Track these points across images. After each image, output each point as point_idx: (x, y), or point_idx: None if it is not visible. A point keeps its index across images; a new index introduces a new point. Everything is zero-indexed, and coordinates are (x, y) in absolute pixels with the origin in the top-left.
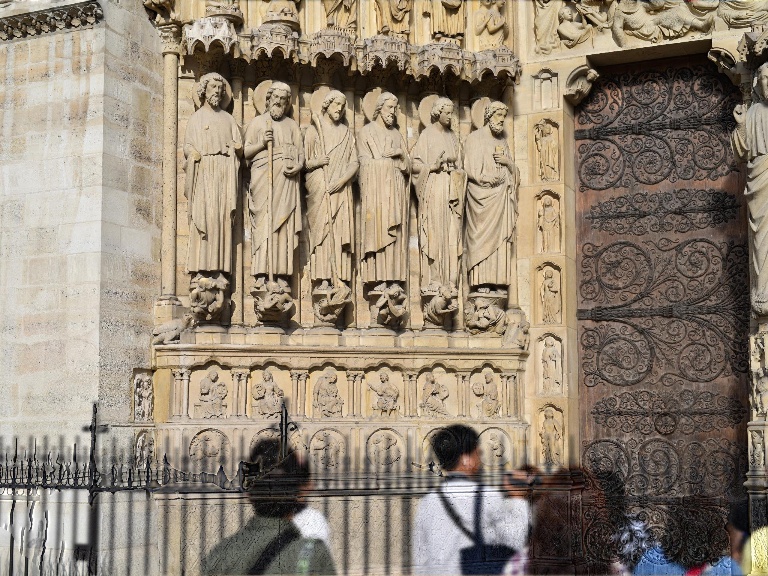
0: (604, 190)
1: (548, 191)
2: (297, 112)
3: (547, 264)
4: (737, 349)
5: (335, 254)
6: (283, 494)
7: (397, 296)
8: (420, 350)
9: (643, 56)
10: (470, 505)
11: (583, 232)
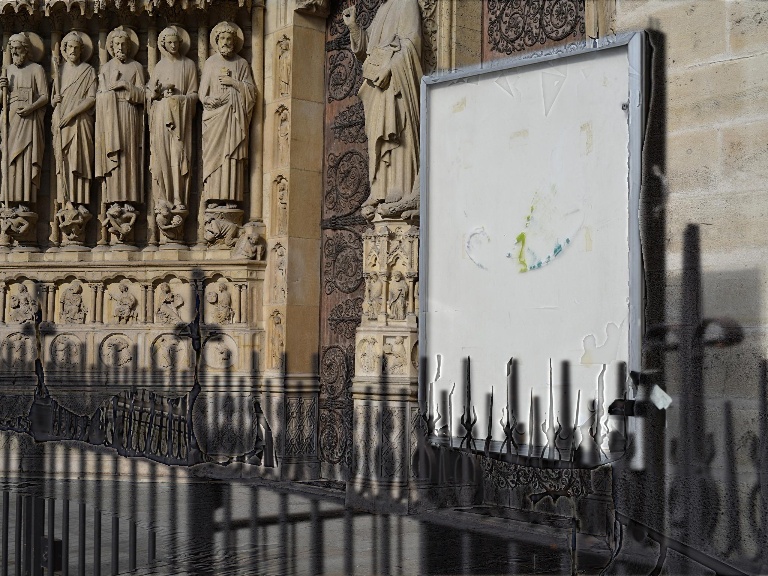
0: (343, 100)
1: (283, 106)
2: (56, 57)
3: (282, 177)
4: None
5: (69, 181)
6: (25, 388)
7: (119, 215)
8: (149, 263)
9: None
10: None
11: (329, 143)
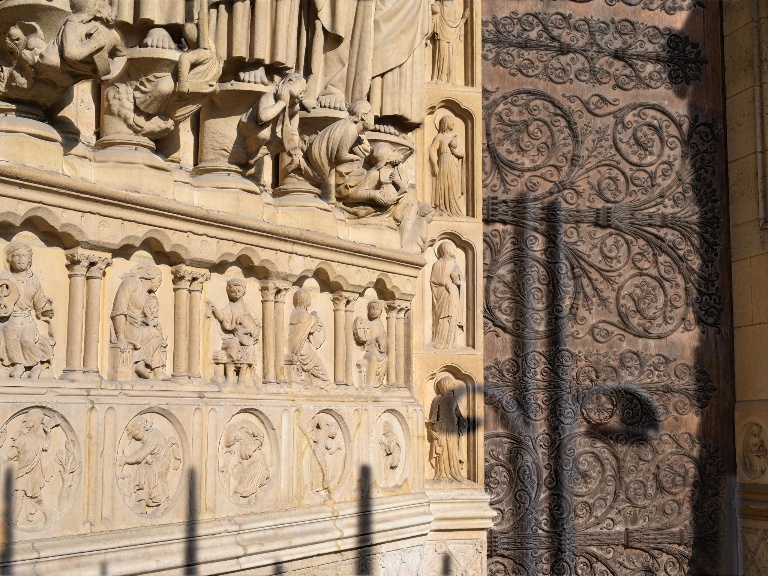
0: None
1: None
2: None
3: (444, 104)
4: (703, 288)
5: None
6: None
7: None
8: (306, 235)
9: None
10: (362, 574)
11: None
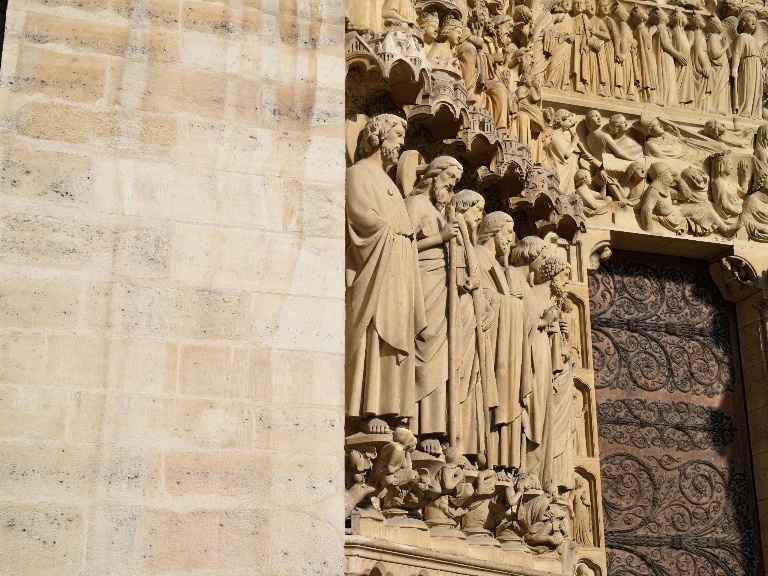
0: (601, 389)
1: (574, 379)
2: None
3: (576, 469)
4: None
5: (478, 419)
6: None
7: None
8: (524, 571)
9: (648, 246)
10: None
11: None
